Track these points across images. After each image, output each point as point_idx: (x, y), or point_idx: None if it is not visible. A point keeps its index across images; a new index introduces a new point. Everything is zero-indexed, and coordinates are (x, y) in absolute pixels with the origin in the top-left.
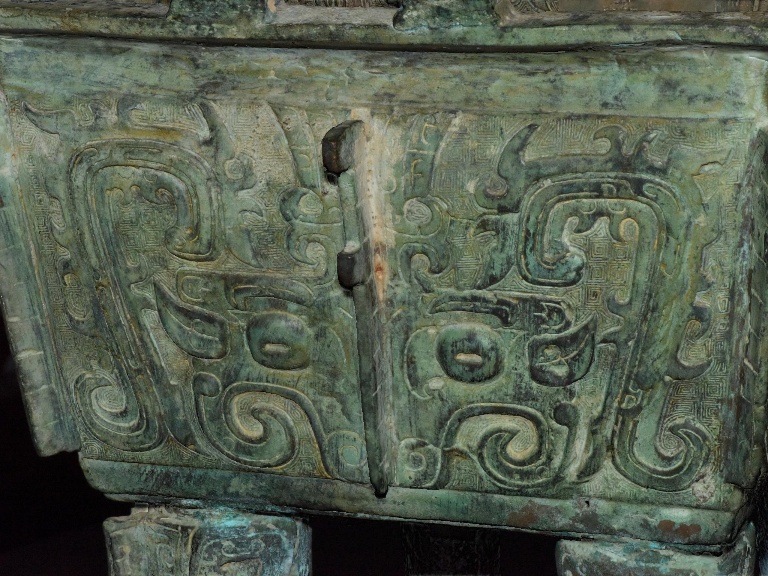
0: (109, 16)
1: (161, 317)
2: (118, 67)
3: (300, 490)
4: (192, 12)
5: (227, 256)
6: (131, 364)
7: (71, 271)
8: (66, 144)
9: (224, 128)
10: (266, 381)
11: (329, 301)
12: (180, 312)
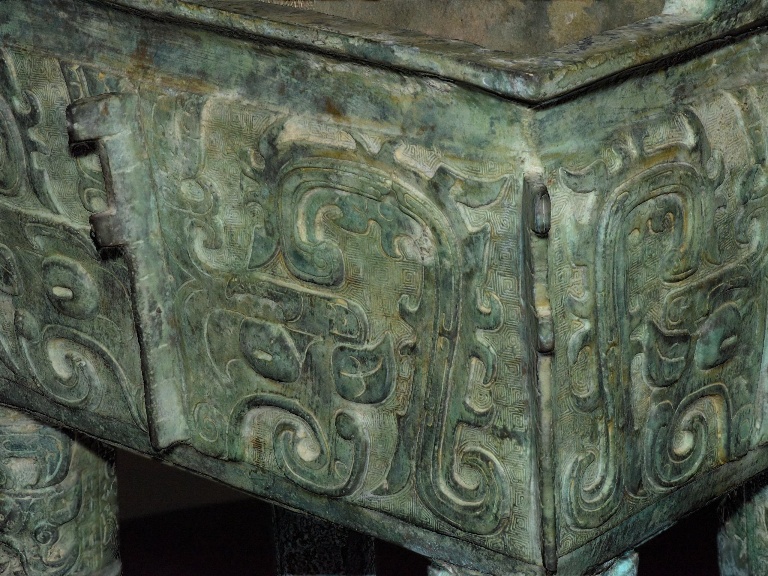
0: (667, 35)
1: (650, 356)
2: (618, 100)
3: (696, 492)
4: (731, 6)
5: (702, 263)
6: (619, 423)
7: (588, 343)
8: (601, 199)
9: (703, 129)
10: (704, 385)
11: (760, 274)
12: (666, 342)
